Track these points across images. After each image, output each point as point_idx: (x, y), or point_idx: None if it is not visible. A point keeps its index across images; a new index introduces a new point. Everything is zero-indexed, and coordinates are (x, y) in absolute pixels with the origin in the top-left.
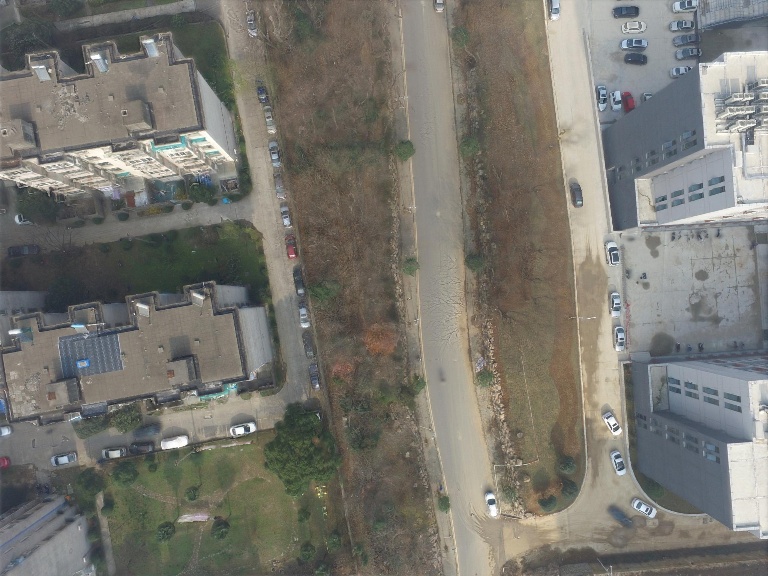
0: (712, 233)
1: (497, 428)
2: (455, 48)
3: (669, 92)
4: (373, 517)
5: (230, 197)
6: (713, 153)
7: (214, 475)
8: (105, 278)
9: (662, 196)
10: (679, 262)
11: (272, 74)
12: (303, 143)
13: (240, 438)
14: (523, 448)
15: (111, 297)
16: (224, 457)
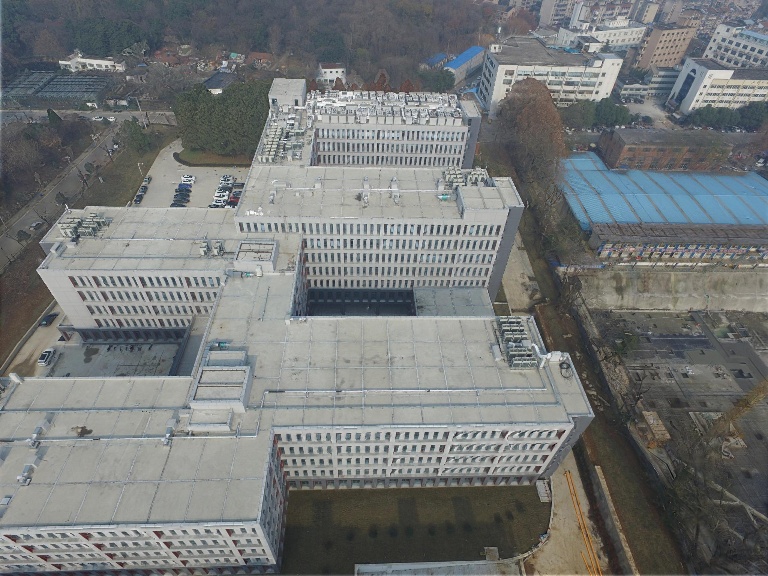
0: (146, 348)
1: None
2: (19, 241)
3: None
4: None
5: None
6: None
7: None
8: None
9: None
10: (106, 367)
11: None
12: None
13: None
14: None
15: None
16: None
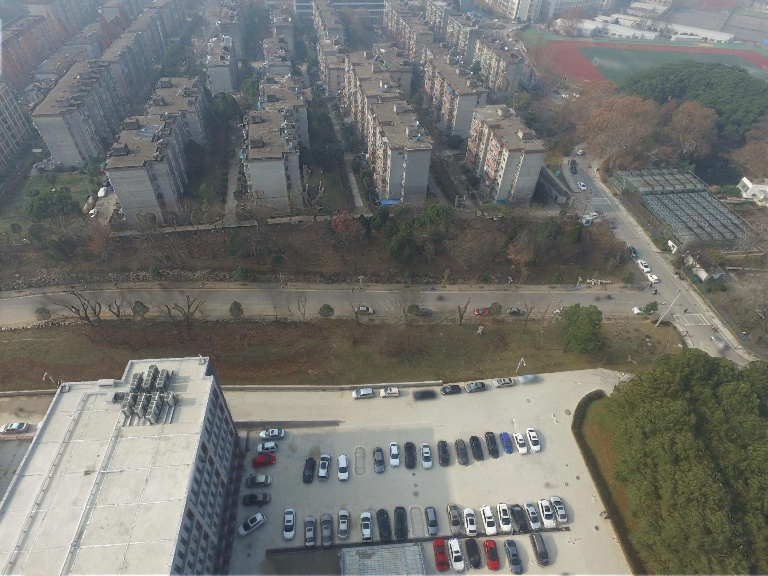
0: None
1: None
2: None
3: None
4: None
5: None
6: None
7: None
8: (202, 165)
9: None
10: None
11: None
12: None
13: None
14: None
15: (197, 175)
16: (81, 208)
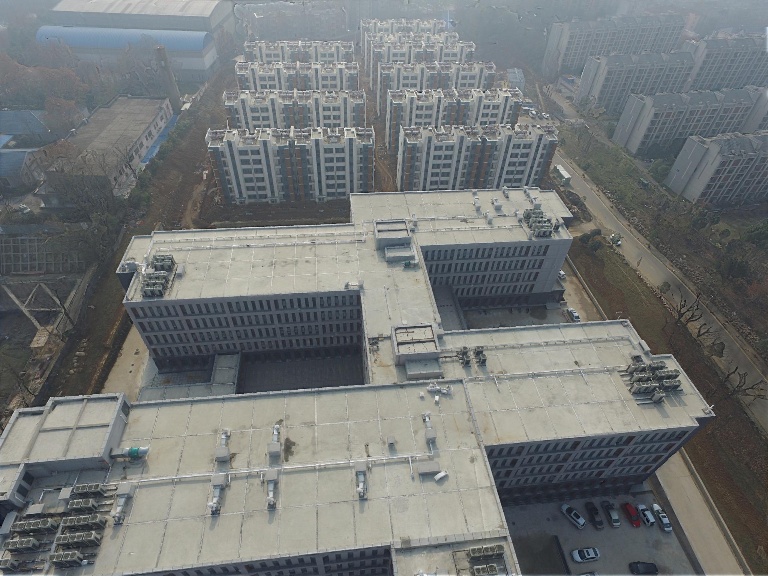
0: None
1: None
2: None
3: None
4: None
5: None
6: None
7: None
8: None
9: None
10: None
11: None
12: None
13: None
14: None
15: None
16: None
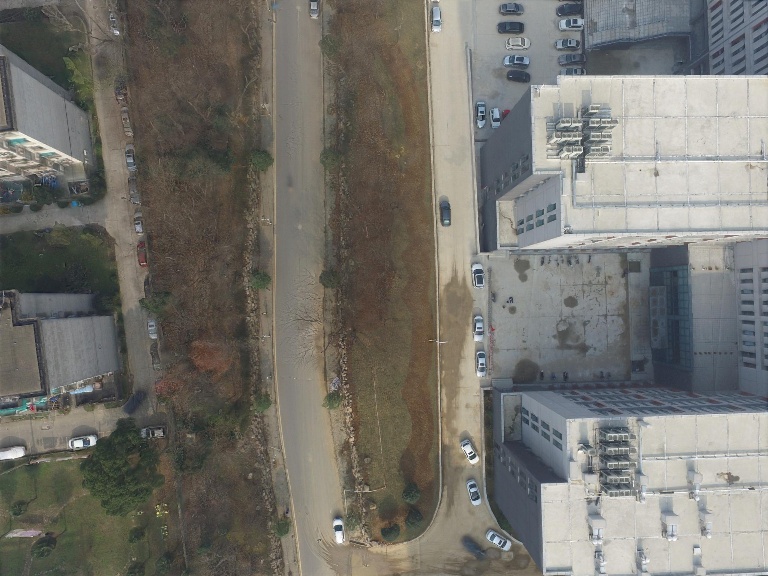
0: (583, 259)
1: (349, 451)
2: None
3: (515, 113)
4: (200, 541)
5: (81, 200)
6: (550, 179)
7: (50, 489)
8: None
9: (521, 219)
10: (548, 287)
11: (129, 74)
12: (161, 147)
13: (80, 451)
14: (370, 474)
15: None
16: (62, 470)
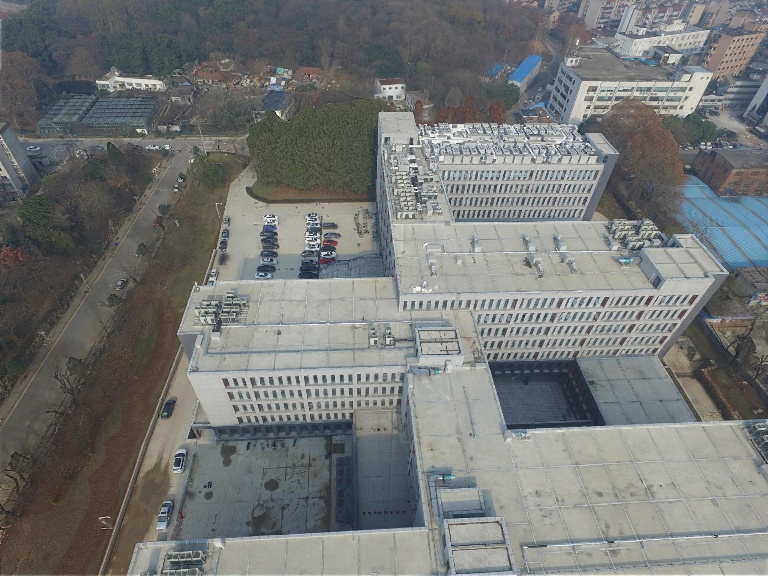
0: (290, 443)
1: None
2: None
3: None
4: None
5: None
6: None
7: None
8: None
9: None
10: (250, 471)
11: None
12: None
13: None
14: None
15: None
16: None
